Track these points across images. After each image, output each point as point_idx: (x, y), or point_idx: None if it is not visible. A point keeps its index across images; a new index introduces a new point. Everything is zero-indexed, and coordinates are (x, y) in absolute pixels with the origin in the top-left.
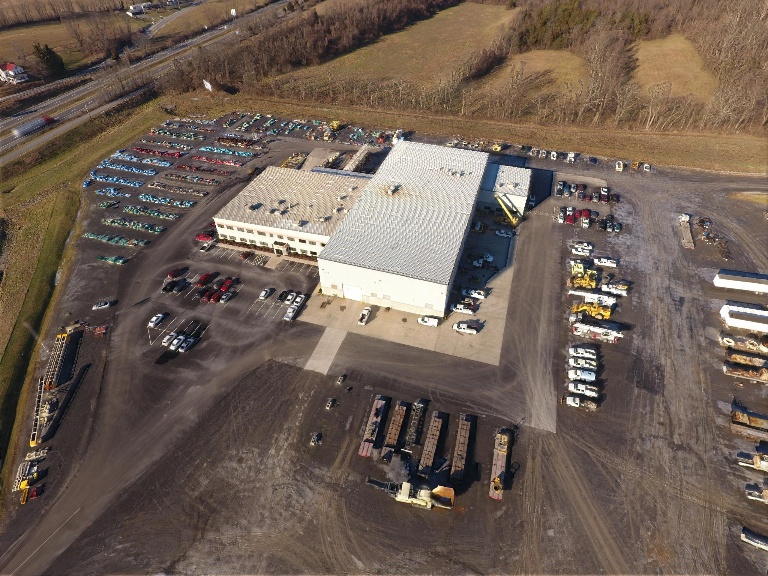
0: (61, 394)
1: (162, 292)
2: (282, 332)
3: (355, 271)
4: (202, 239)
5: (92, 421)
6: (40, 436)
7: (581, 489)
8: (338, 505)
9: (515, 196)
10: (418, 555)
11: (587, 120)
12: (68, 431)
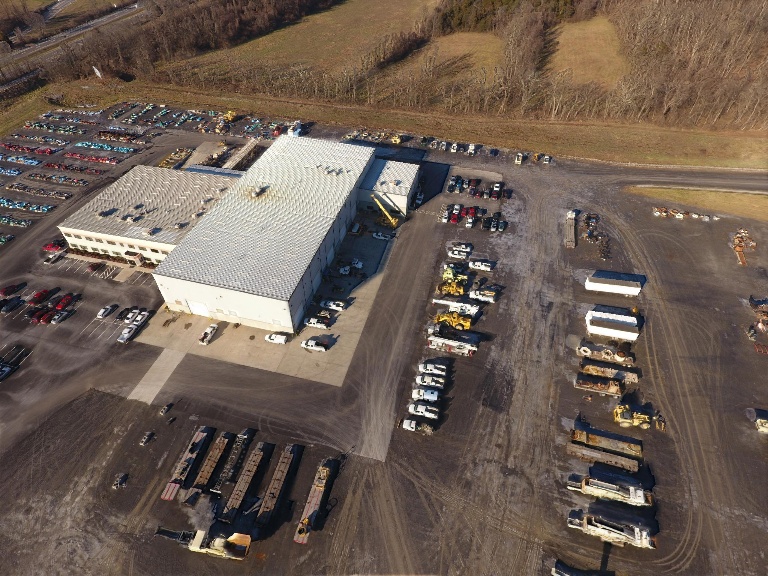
0: None
1: None
2: (113, 356)
3: (193, 287)
4: (50, 249)
5: None
6: None
7: (397, 525)
8: (126, 559)
9: (395, 195)
10: None
11: (494, 109)
12: None
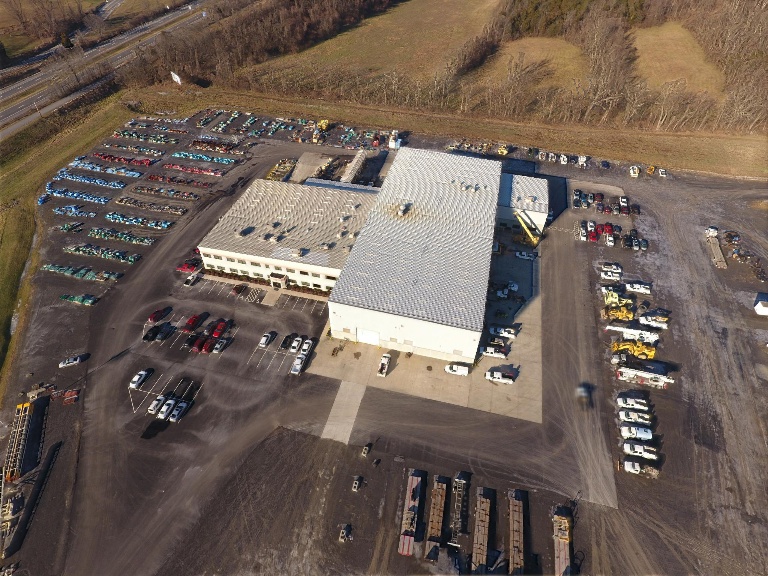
0: (27, 486)
1: (143, 341)
2: (290, 389)
3: (373, 315)
4: (185, 270)
5: (68, 523)
6: (3, 548)
7: None
8: None
9: (535, 212)
10: None
11: (594, 119)
12: (38, 539)
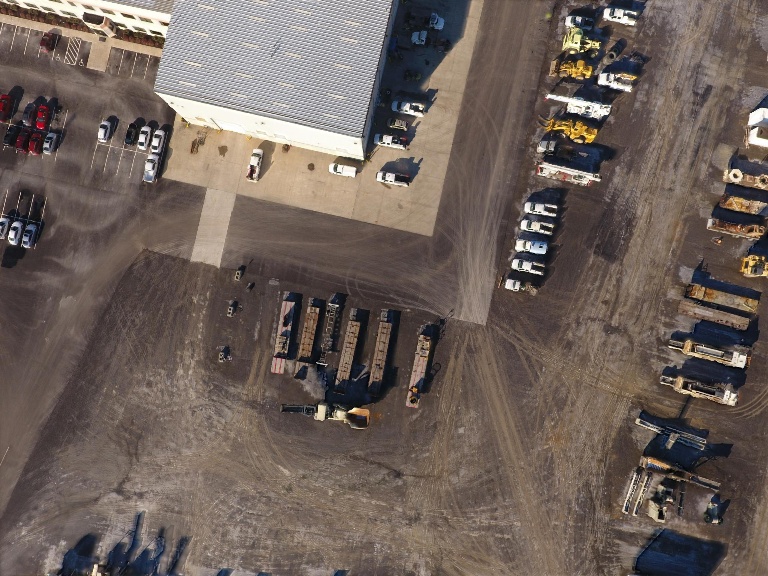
0: None
1: None
2: (148, 202)
3: (221, 110)
4: None
5: None
6: None
7: (499, 386)
8: (259, 422)
9: None
10: (338, 460)
11: None
12: None
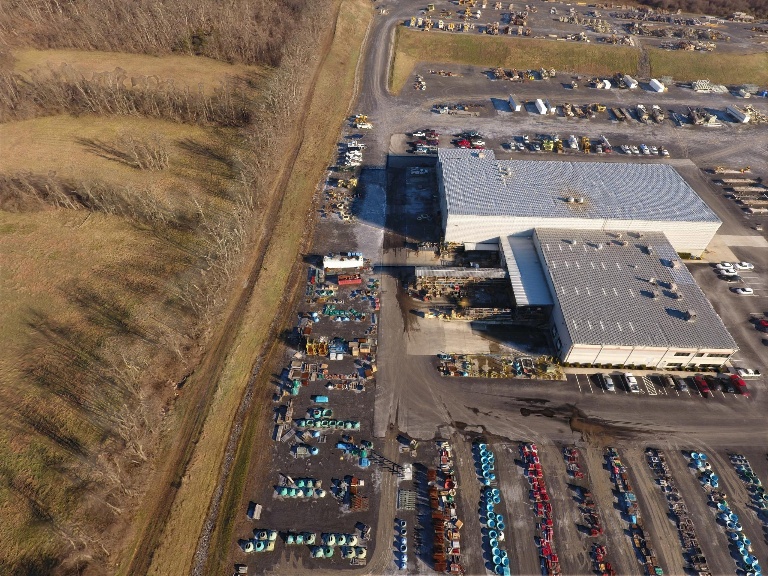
0: None
1: None
2: (763, 268)
3: None
4: None
5: None
6: None
7: None
8: None
9: None
10: None
11: None
12: None
